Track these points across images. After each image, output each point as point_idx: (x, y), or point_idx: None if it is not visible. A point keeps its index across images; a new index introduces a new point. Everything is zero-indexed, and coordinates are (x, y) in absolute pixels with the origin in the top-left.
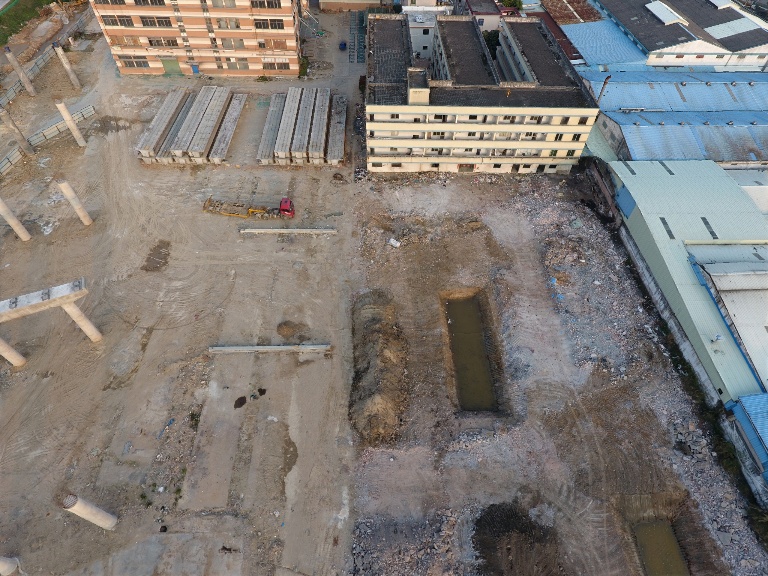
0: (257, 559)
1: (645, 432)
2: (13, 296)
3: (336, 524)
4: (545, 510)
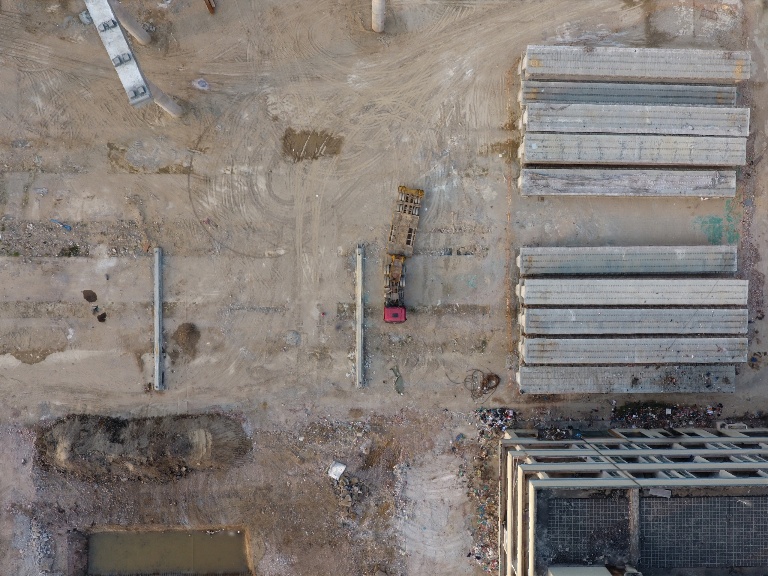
0: None
1: None
2: None
3: None
4: None
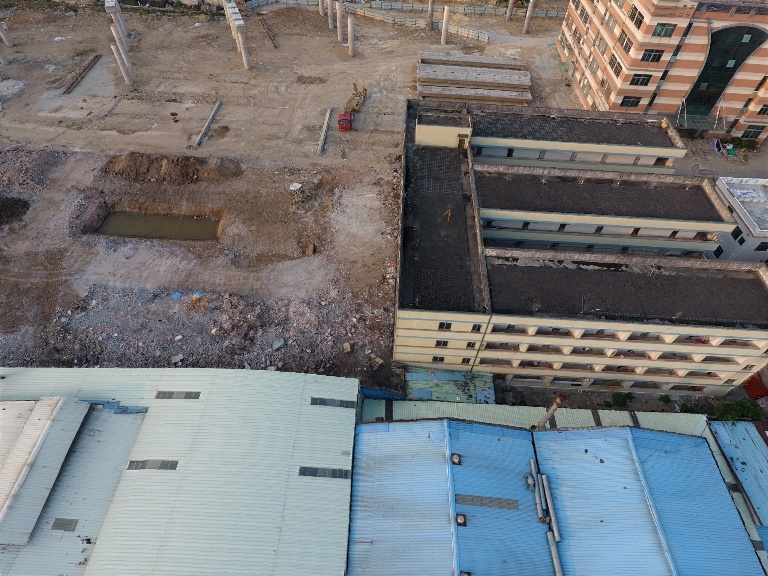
0: (77, 122)
1: (0, 318)
2: (292, 43)
3: (73, 146)
4: (2, 234)
